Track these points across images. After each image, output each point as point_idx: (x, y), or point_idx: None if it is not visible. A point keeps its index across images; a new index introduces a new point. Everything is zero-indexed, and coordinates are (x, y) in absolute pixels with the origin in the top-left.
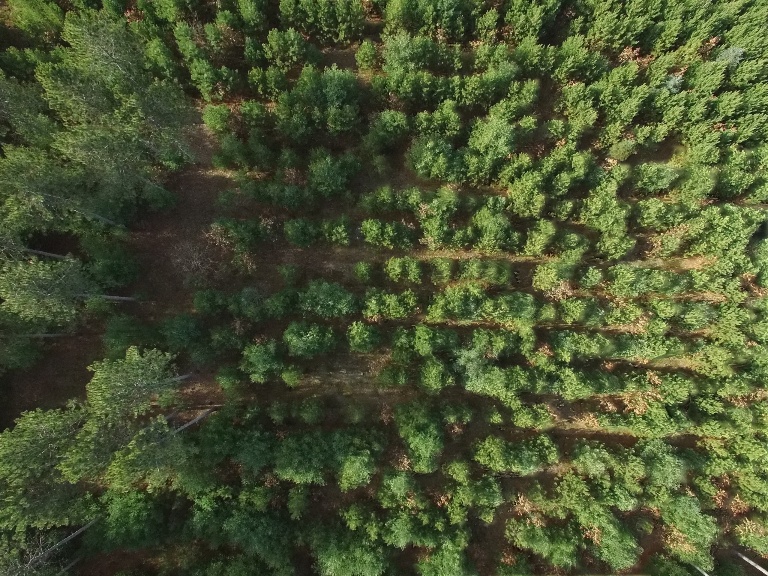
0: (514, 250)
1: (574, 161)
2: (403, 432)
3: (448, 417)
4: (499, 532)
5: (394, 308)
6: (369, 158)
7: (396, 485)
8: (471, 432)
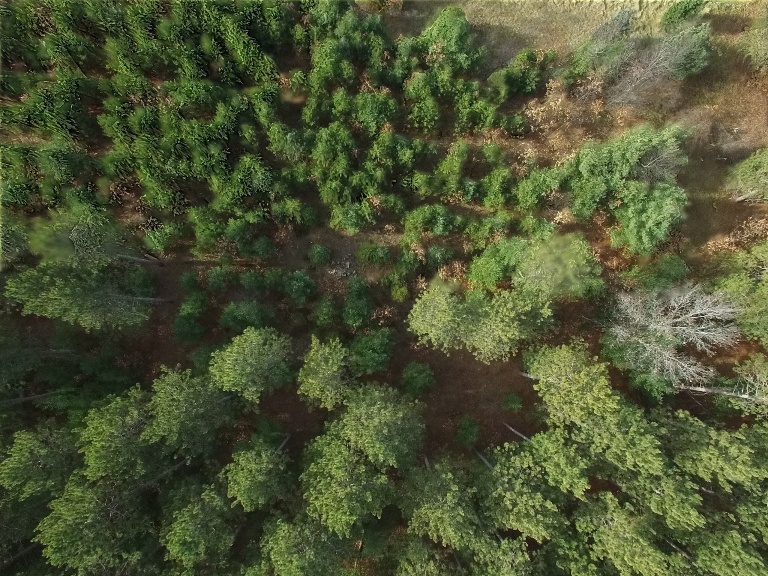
0: None
1: None
2: None
3: None
4: None
5: None
6: None
7: None
8: None
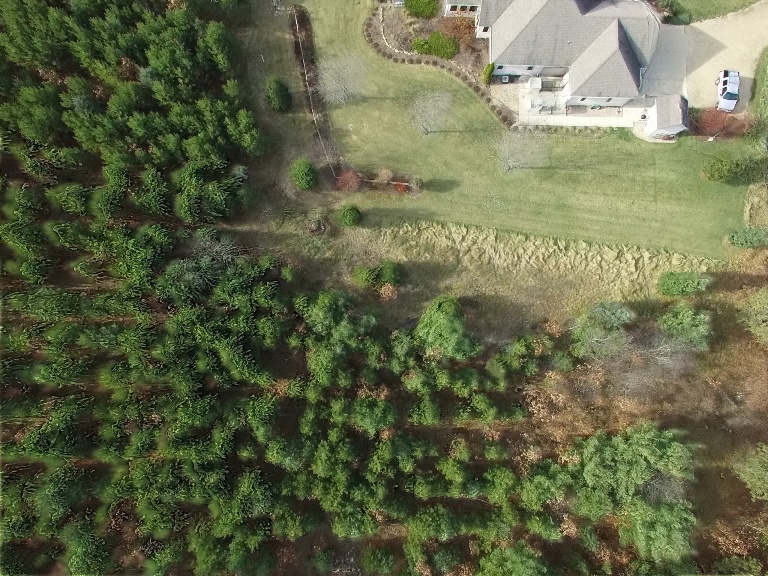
0: None
1: None
2: None
3: None
4: None
5: None
6: None
7: None
8: None
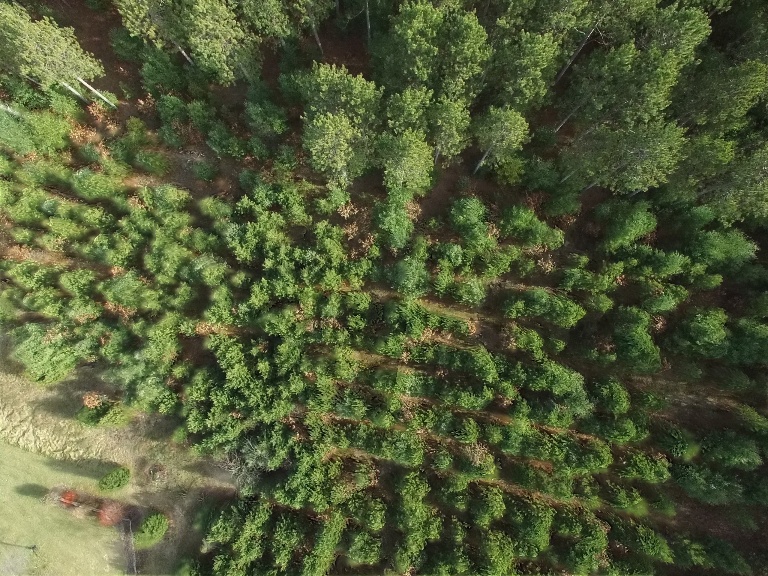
0: None
1: None
2: None
3: None
4: None
5: (645, 466)
6: None
7: None
8: None
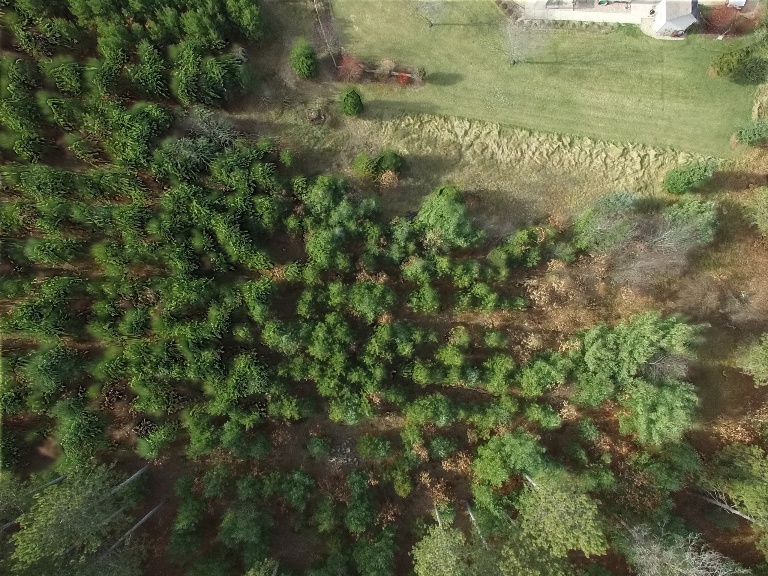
0: None
1: None
2: None
3: None
4: None
5: None
6: None
7: None
8: None
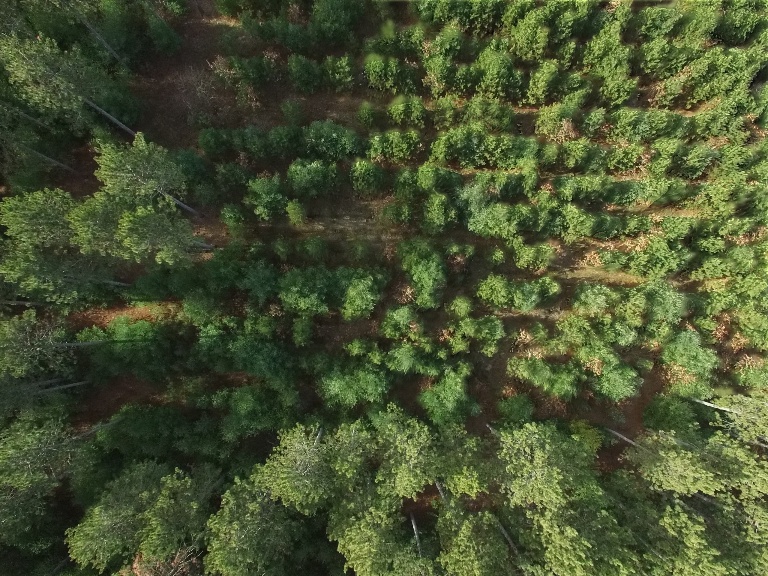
0: (517, 100)
1: (578, 0)
2: (406, 262)
3: (450, 247)
4: (501, 371)
5: (397, 146)
6: (372, 3)
7: (399, 314)
8: (473, 279)
